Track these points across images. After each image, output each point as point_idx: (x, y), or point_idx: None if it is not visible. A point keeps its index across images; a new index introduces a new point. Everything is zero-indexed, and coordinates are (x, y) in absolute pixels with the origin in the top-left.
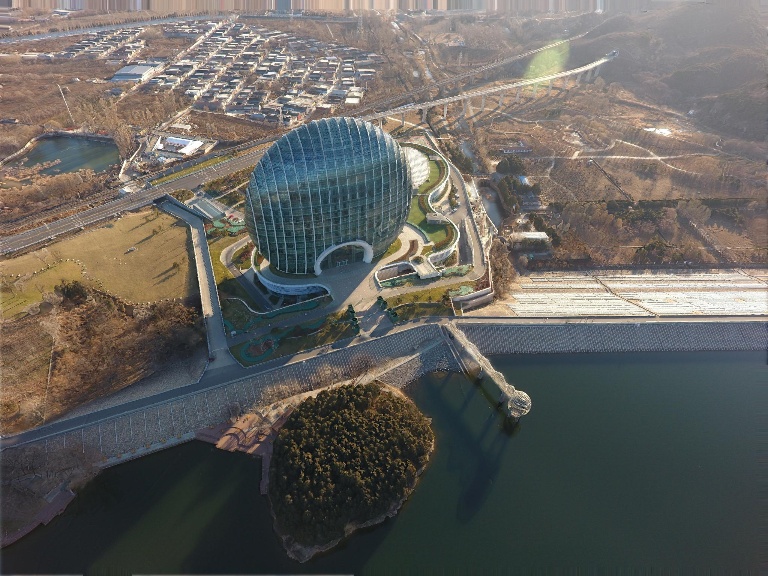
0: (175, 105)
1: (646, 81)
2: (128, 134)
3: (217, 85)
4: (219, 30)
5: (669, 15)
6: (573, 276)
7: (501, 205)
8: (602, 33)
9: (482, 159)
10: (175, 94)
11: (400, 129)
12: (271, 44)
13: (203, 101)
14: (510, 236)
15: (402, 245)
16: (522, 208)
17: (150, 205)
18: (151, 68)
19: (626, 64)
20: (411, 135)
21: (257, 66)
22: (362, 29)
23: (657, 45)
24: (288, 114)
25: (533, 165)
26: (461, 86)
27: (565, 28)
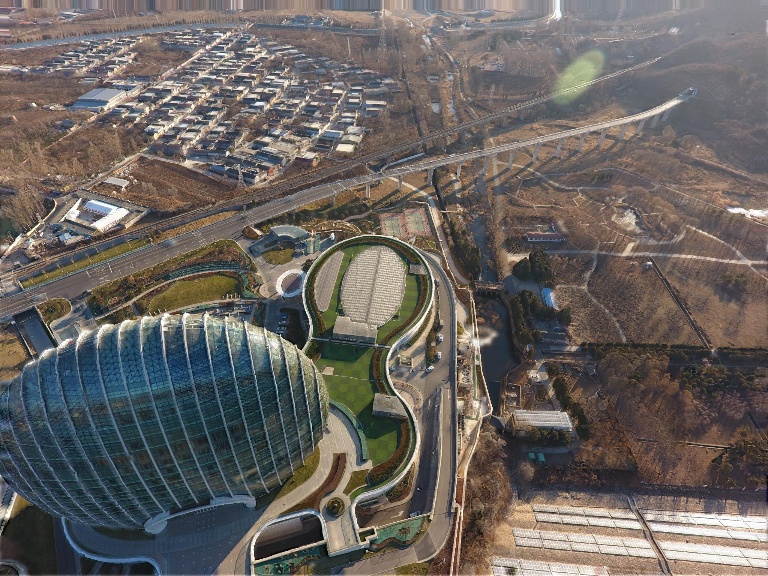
0: (121, 150)
1: (732, 134)
2: (32, 198)
3: (188, 119)
4: (223, 42)
5: (766, 42)
6: (605, 508)
7: (511, 337)
8: (676, 62)
9: (496, 250)
10: (134, 130)
11: (395, 195)
12: (273, 63)
13: (160, 143)
14: (512, 414)
15: (319, 465)
16: (540, 348)
17: (6, 323)
18: (121, 92)
19: (705, 107)
20: (406, 207)
21: (248, 92)
22: (384, 46)
23: (749, 83)
24: (257, 166)
25: (566, 265)
26: (489, 128)
27: (629, 53)
